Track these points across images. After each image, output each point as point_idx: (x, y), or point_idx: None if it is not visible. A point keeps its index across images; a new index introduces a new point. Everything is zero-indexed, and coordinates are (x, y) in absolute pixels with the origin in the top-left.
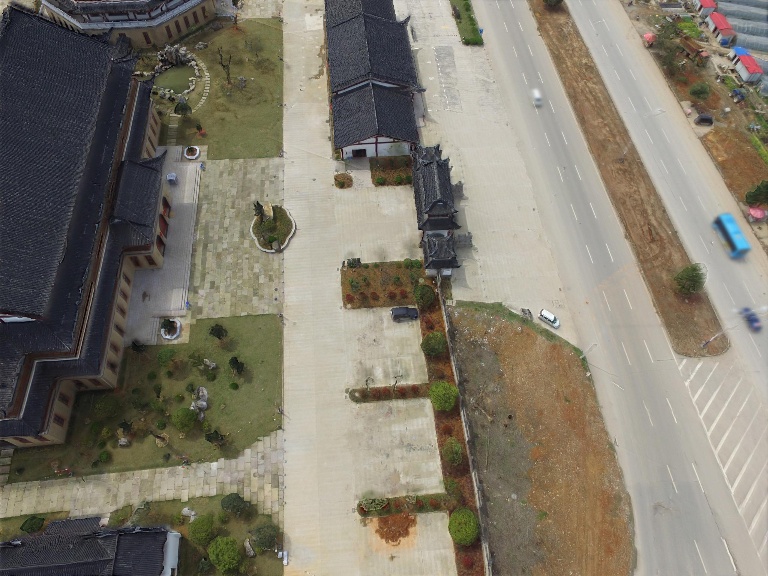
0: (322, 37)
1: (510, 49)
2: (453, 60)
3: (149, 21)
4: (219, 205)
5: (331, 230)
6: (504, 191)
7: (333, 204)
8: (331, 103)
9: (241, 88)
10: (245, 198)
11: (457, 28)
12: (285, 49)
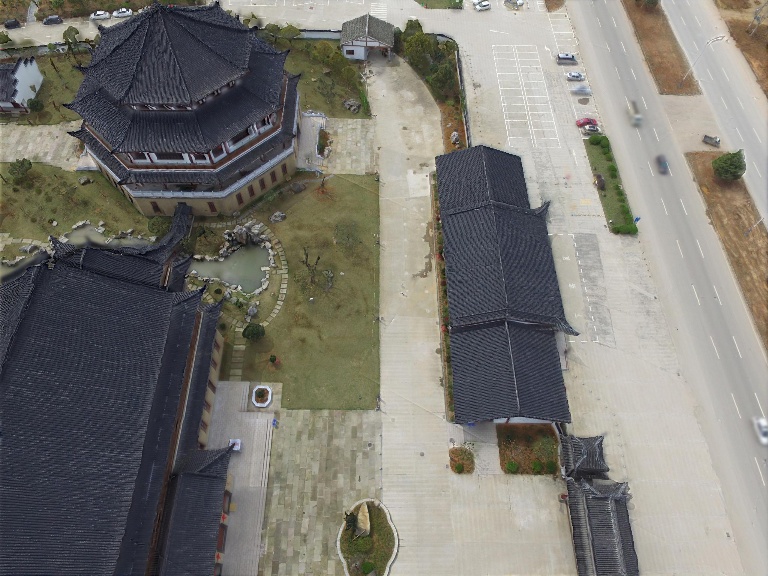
0: (429, 209)
1: (673, 244)
2: (599, 257)
3: (217, 192)
4: (295, 492)
5: (447, 551)
6: (683, 496)
7: (449, 502)
8: (443, 321)
9: (327, 289)
10: (330, 481)
11: (601, 204)
12: (382, 225)
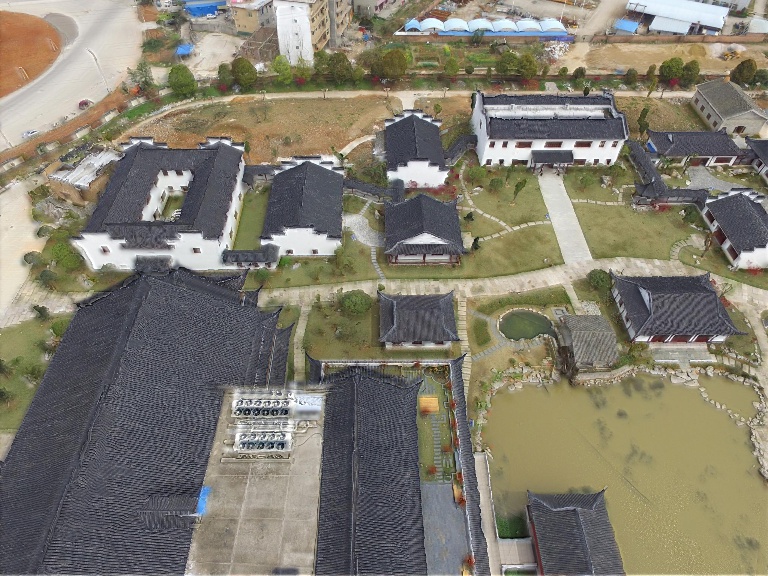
0: None
1: None
2: None
3: None
4: None
5: None
6: None
7: None
8: None
9: None
10: None
11: None
12: None
